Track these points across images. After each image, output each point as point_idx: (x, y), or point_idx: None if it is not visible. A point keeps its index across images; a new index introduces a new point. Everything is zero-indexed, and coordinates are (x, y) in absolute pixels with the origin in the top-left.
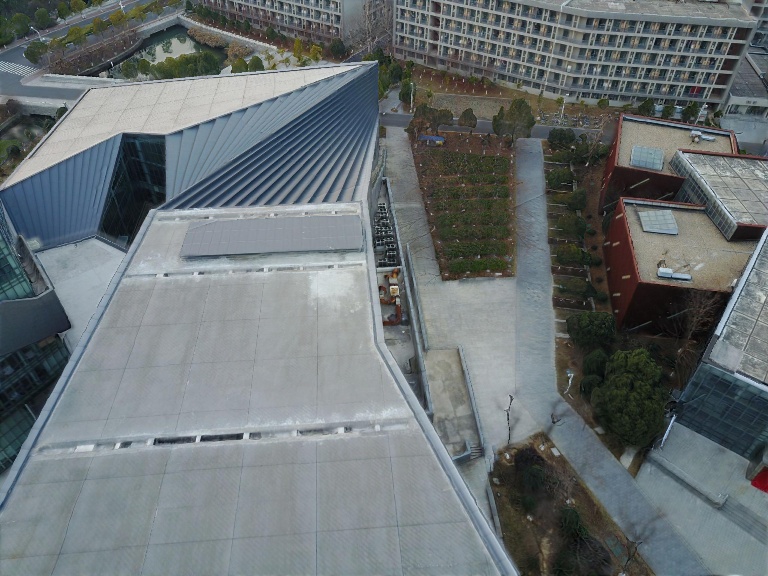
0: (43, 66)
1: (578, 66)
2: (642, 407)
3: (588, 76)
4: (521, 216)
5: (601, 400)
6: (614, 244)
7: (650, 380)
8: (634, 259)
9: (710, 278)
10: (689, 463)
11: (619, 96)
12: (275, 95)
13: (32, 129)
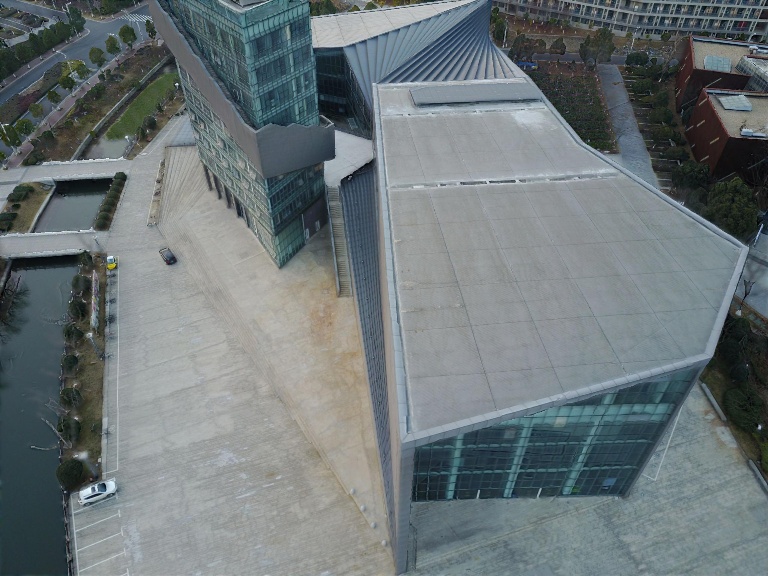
0: None
1: (644, 6)
2: (742, 212)
3: (652, 14)
4: (614, 116)
5: (709, 213)
6: (699, 124)
7: (745, 197)
8: (722, 124)
9: None
10: None
11: (678, 31)
12: (418, 20)
13: None
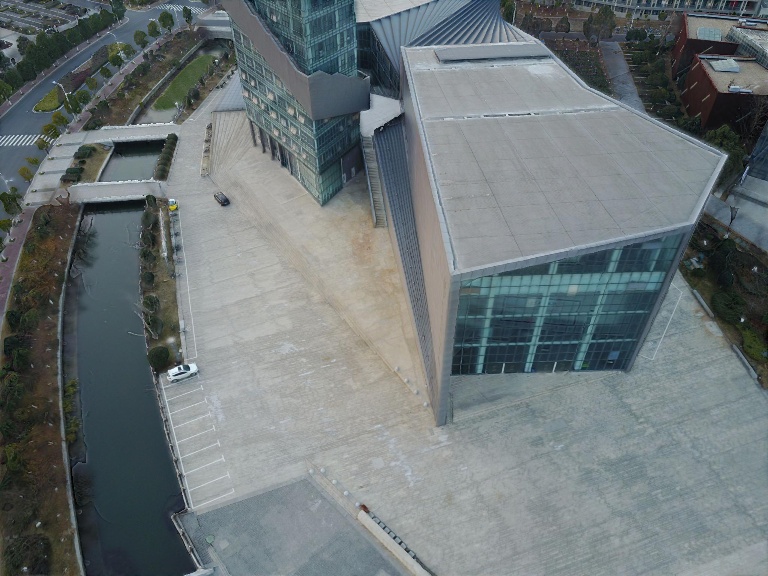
0: (210, 7)
1: None
2: (730, 153)
3: None
4: (616, 84)
5: None
6: (692, 86)
7: None
8: (712, 82)
9: (765, 92)
10: (759, 192)
11: (674, 12)
12: None
13: (220, 48)
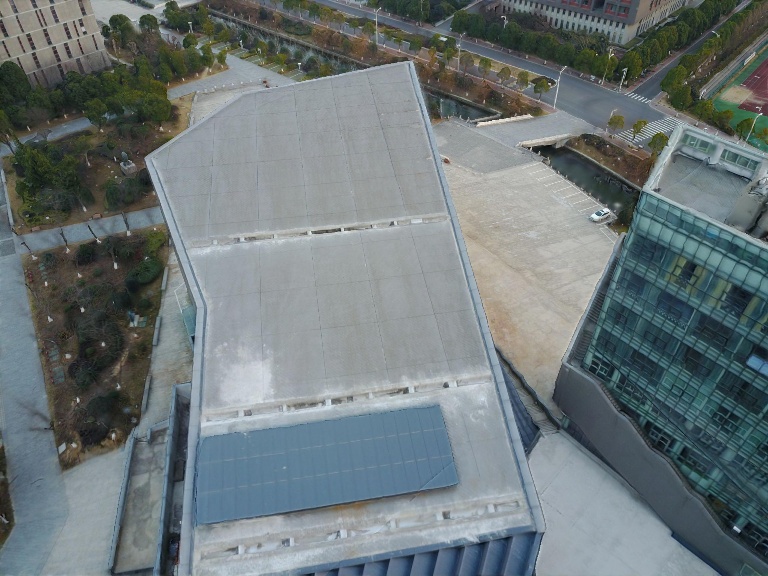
0: None
1: None
2: None
3: None
4: None
5: None
6: None
7: None
8: None
9: None
10: None
11: None
12: None
13: None
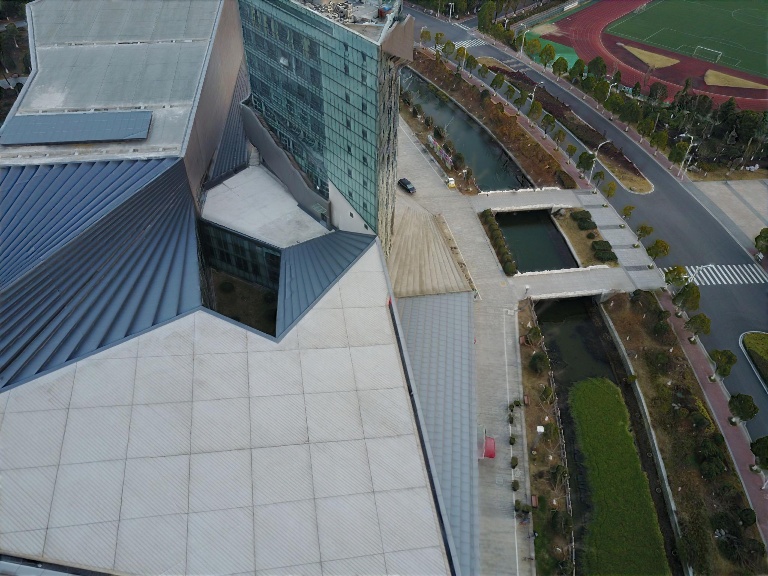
0: None
1: None
2: None
3: None
4: None
5: None
6: None
7: None
8: None
9: None
10: None
11: None
12: (5, 395)
13: None
